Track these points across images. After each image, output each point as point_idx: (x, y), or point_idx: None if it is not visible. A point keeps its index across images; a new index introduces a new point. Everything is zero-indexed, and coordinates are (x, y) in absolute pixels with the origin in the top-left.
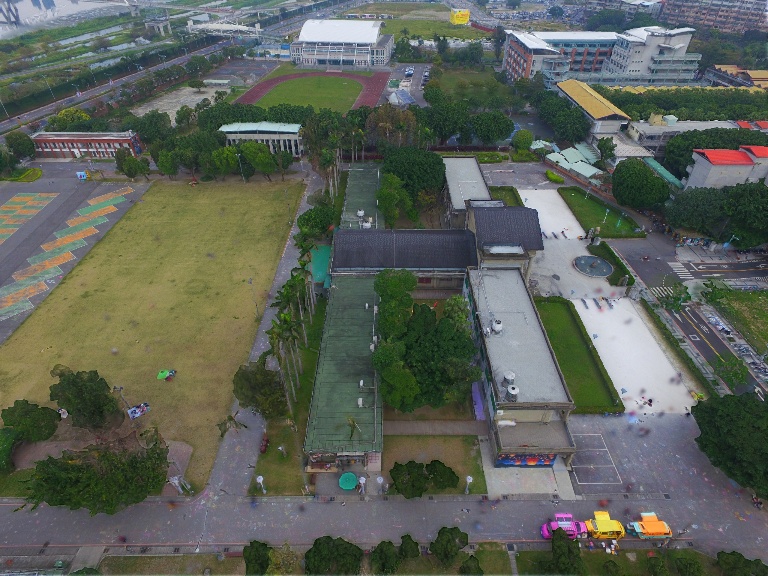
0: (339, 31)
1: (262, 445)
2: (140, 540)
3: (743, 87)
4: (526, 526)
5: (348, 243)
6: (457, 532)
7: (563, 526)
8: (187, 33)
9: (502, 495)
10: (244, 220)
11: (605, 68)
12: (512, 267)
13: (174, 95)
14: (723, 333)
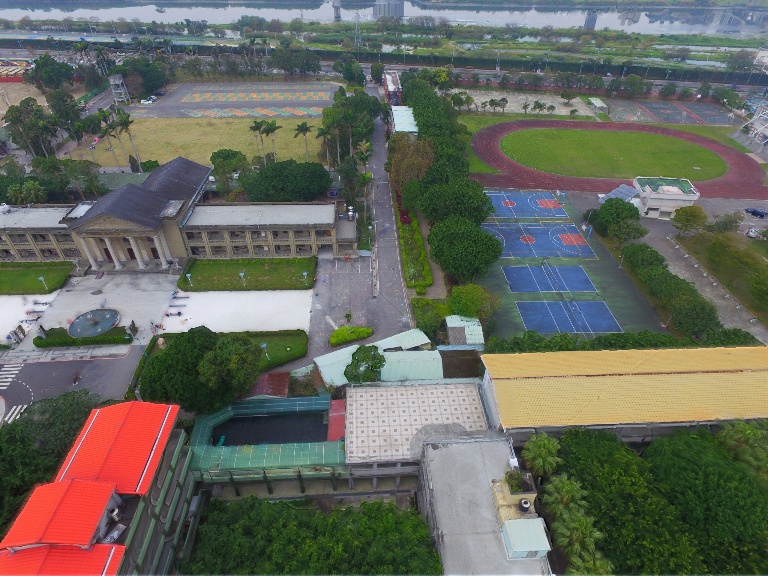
0: None
1: None
2: (17, 159)
3: None
4: None
5: (169, 164)
6: None
7: None
8: (751, 64)
9: None
10: (271, 149)
11: None
12: None
13: (549, 97)
14: None
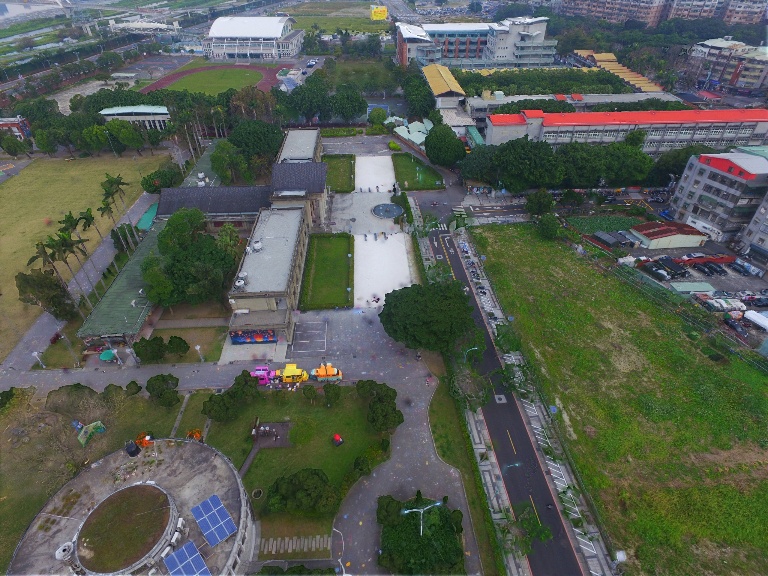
0: (247, 27)
1: (52, 337)
2: None
3: (584, 68)
4: None
5: (172, 195)
6: (168, 376)
7: (258, 373)
8: (110, 32)
9: (229, 361)
10: None
11: (484, 55)
12: (297, 207)
13: (81, 88)
14: (464, 253)
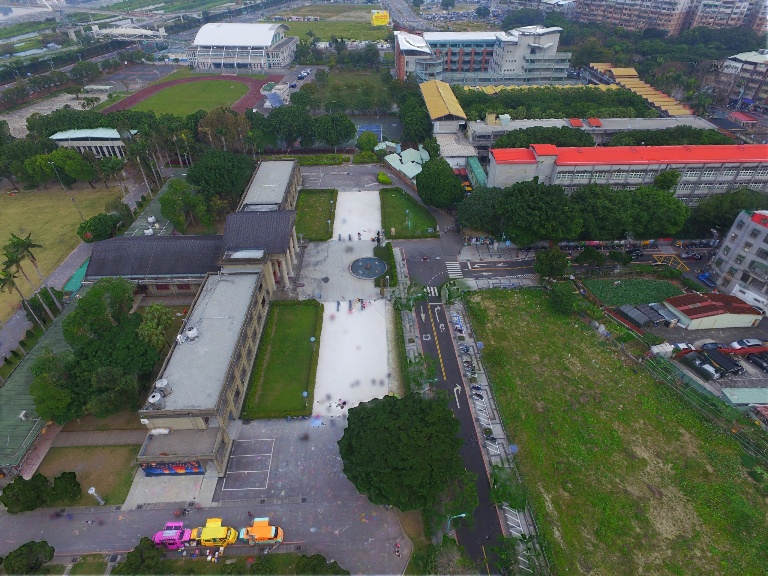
0: (235, 34)
1: None
2: None
3: (601, 85)
4: (142, 536)
5: (106, 251)
6: (38, 546)
7: (167, 535)
8: (93, 38)
9: (138, 505)
10: (42, 229)
11: (490, 68)
12: (252, 272)
13: (50, 102)
14: (457, 332)
